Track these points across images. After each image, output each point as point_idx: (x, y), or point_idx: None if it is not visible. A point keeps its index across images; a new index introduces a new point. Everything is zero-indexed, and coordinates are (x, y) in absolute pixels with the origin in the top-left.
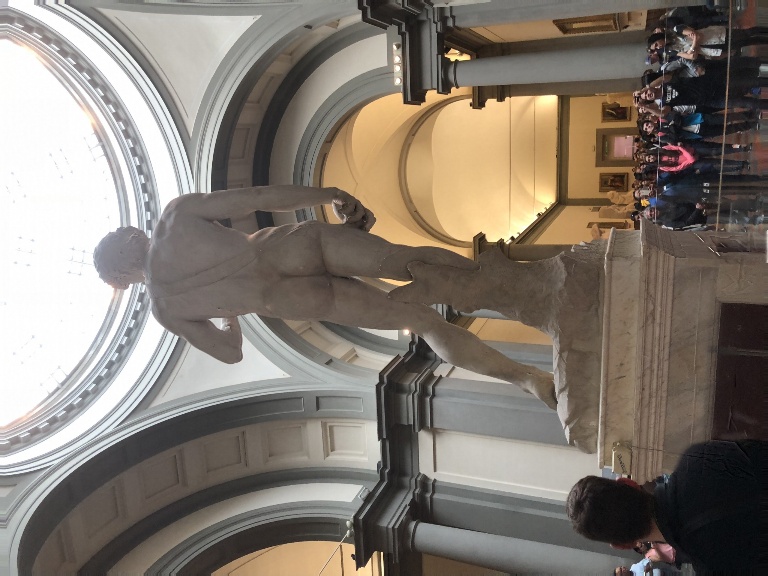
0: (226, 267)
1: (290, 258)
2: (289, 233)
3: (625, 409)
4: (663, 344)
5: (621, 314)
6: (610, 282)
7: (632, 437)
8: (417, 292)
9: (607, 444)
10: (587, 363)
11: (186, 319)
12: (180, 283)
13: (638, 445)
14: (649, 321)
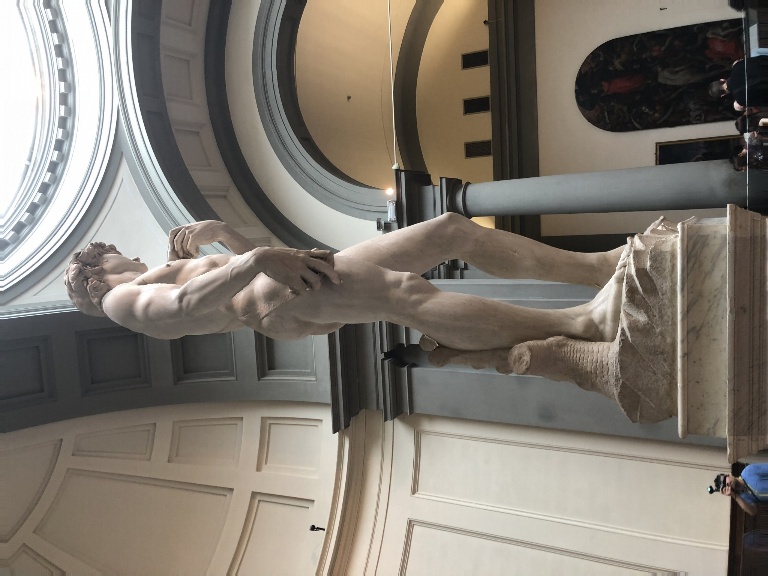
0: None
1: None
2: (264, 326)
3: None
4: None
5: None
6: None
7: None
8: None
9: None
10: None
11: None
12: None
13: None
14: None
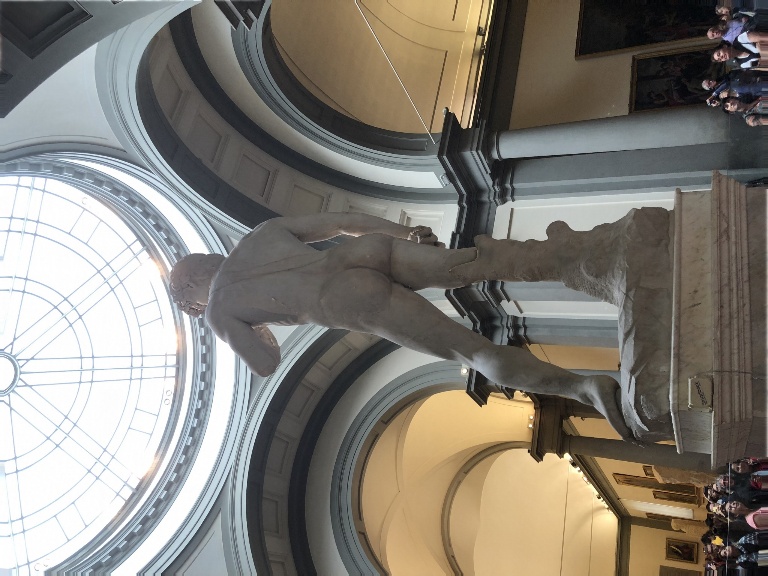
0: (295, 261)
1: (360, 246)
2: None
3: (702, 340)
4: (741, 264)
5: (693, 242)
6: (680, 213)
7: (712, 364)
8: (479, 263)
9: (681, 383)
10: (657, 300)
11: (235, 316)
12: (246, 271)
13: (720, 368)
14: (723, 238)
